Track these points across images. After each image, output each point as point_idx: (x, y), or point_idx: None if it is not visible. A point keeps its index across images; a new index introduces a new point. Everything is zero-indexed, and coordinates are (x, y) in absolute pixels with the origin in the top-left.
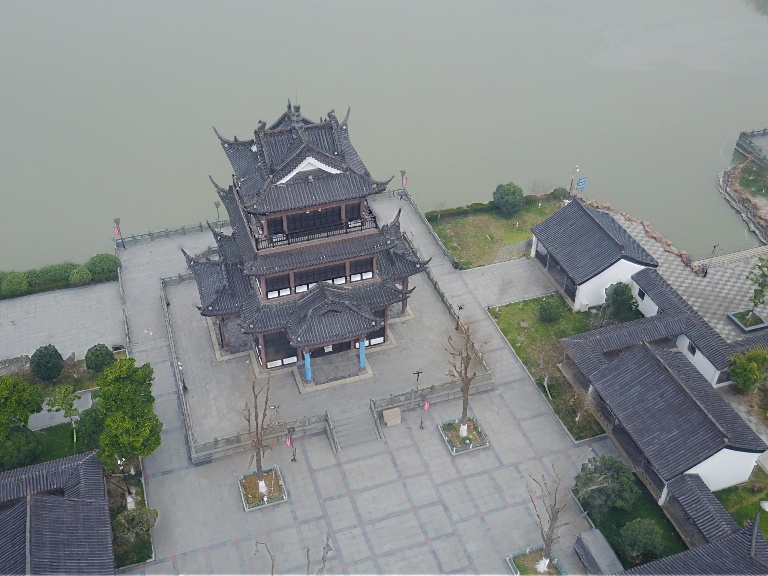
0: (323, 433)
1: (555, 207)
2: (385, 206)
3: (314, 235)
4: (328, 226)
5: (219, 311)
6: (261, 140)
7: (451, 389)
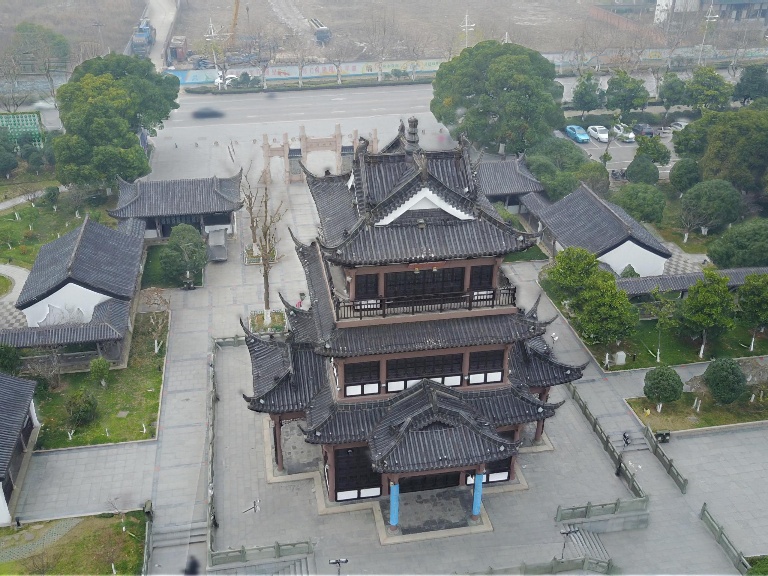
0: None
1: None
2: None
3: None
4: None
5: None
6: None
7: None
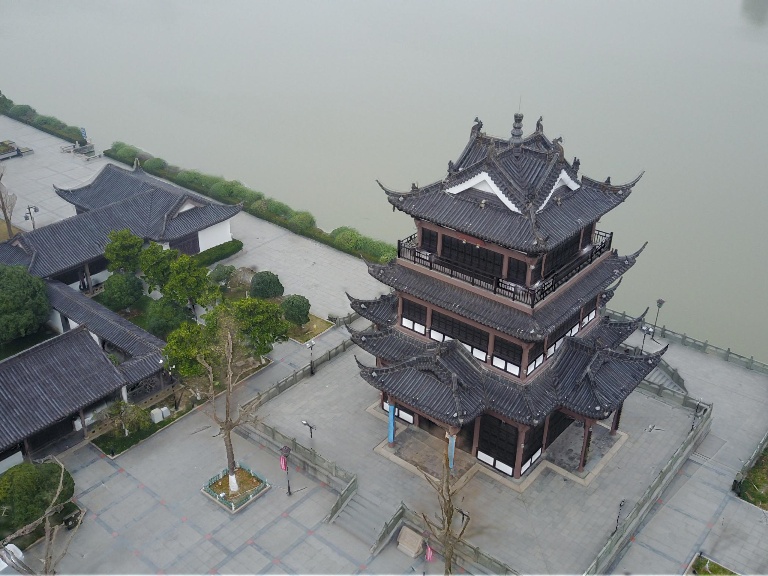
0: None
1: None
2: (752, 380)
3: (459, 273)
4: (476, 270)
5: (370, 315)
6: None
7: (502, 575)
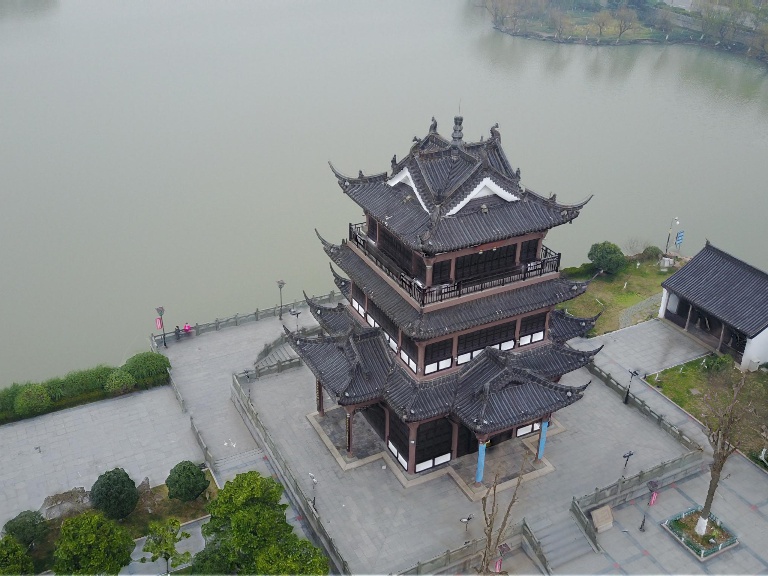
0: (518, 551)
1: (654, 266)
2: None
3: (488, 283)
4: (505, 270)
5: (357, 398)
6: (417, 163)
7: (659, 475)
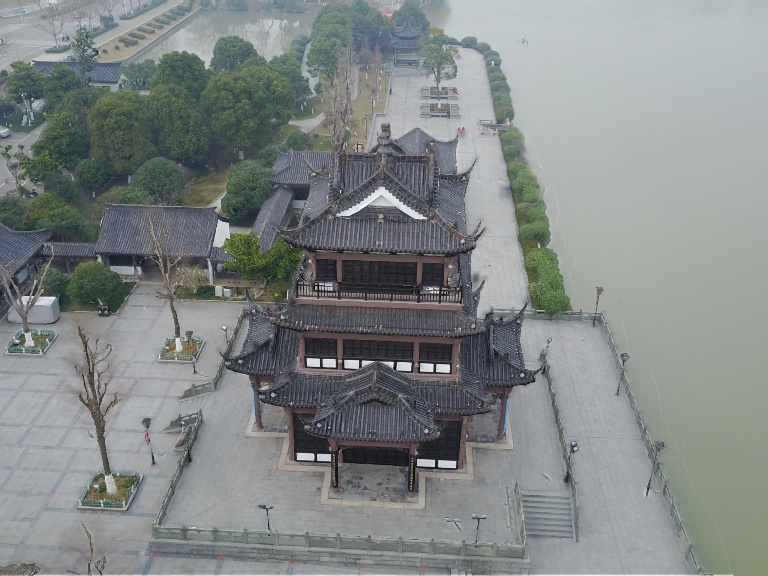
0: None
1: None
2: None
3: None
4: None
5: None
6: None
7: None
